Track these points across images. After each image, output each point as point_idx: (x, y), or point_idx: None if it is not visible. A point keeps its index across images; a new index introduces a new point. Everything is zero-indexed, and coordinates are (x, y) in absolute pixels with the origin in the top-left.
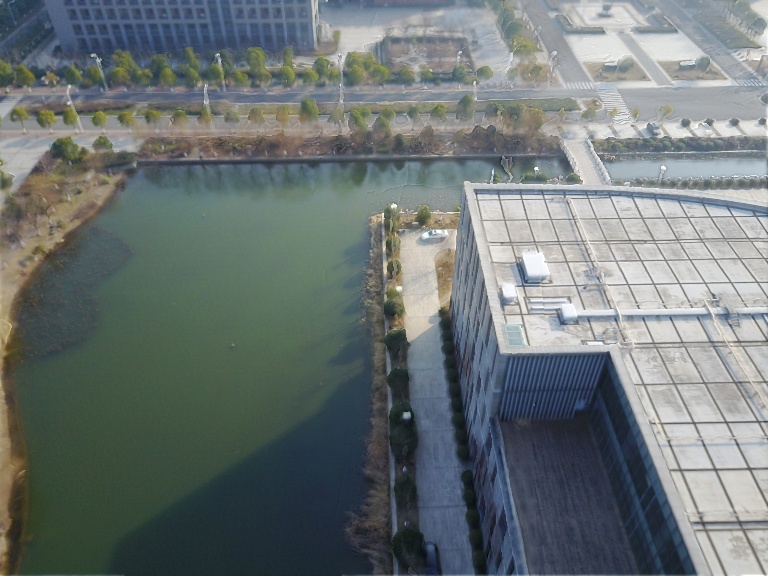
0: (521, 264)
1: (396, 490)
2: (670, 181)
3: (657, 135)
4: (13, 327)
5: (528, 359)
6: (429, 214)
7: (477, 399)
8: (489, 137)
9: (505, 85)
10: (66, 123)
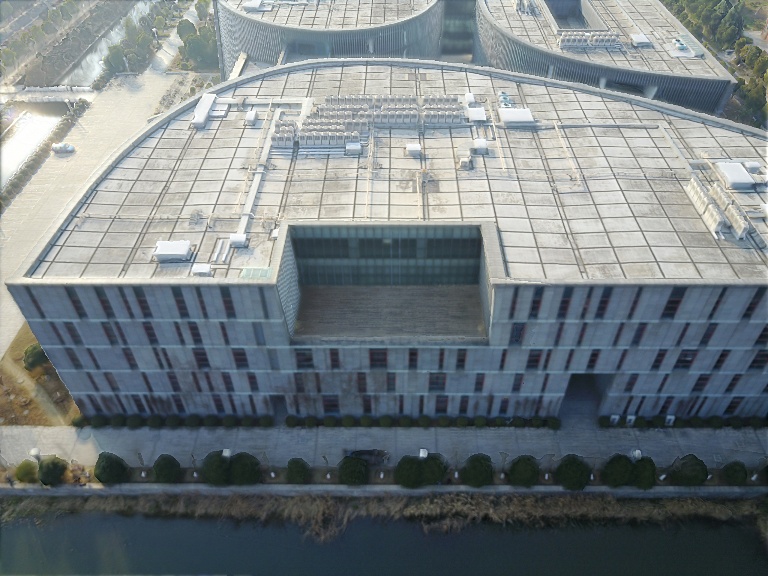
0: (164, 259)
1: (300, 476)
2: None
3: None
4: None
5: (279, 274)
6: None
7: (249, 368)
8: None
9: None
10: None
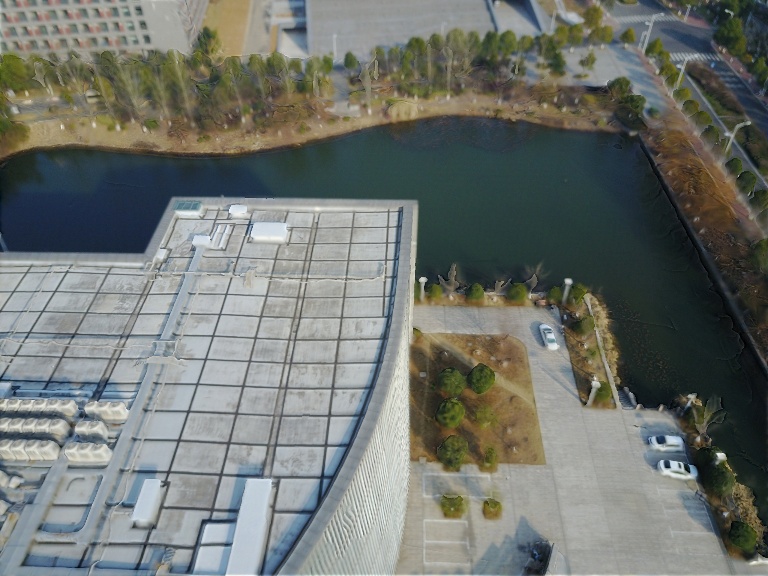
0: None
1: None
2: None
3: None
4: (421, 122)
5: None
6: (581, 327)
7: None
8: None
9: None
10: (665, 81)
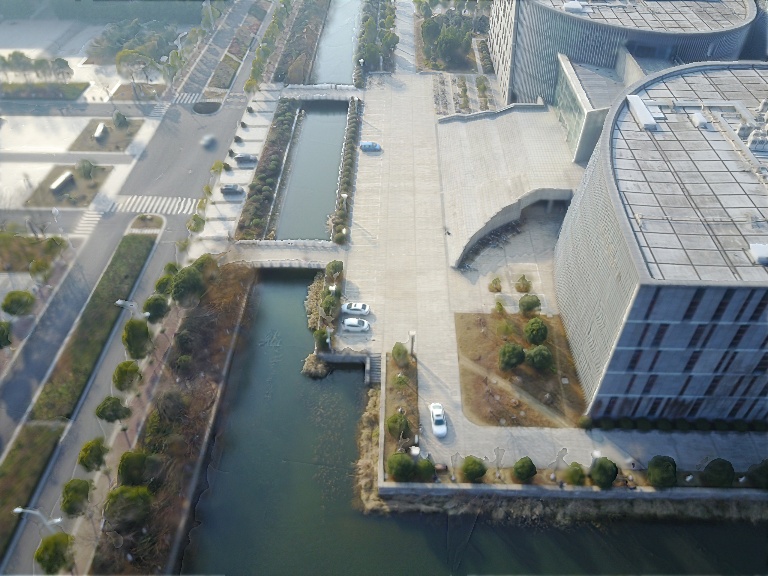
0: None
1: None
2: (342, 203)
3: (244, 191)
4: None
5: None
6: None
7: None
8: (205, 330)
9: (35, 294)
10: None
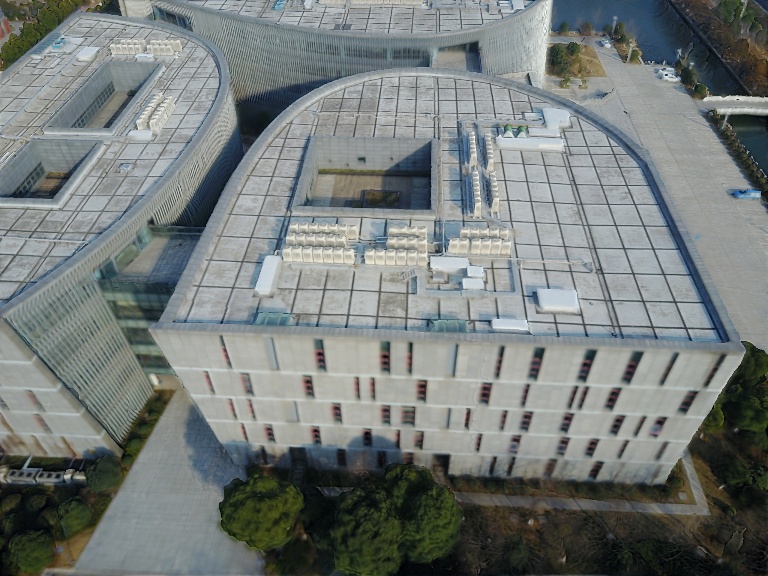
0: None
1: None
2: None
3: None
4: None
5: None
6: (623, 37)
7: None
8: (755, 67)
9: None
10: None
